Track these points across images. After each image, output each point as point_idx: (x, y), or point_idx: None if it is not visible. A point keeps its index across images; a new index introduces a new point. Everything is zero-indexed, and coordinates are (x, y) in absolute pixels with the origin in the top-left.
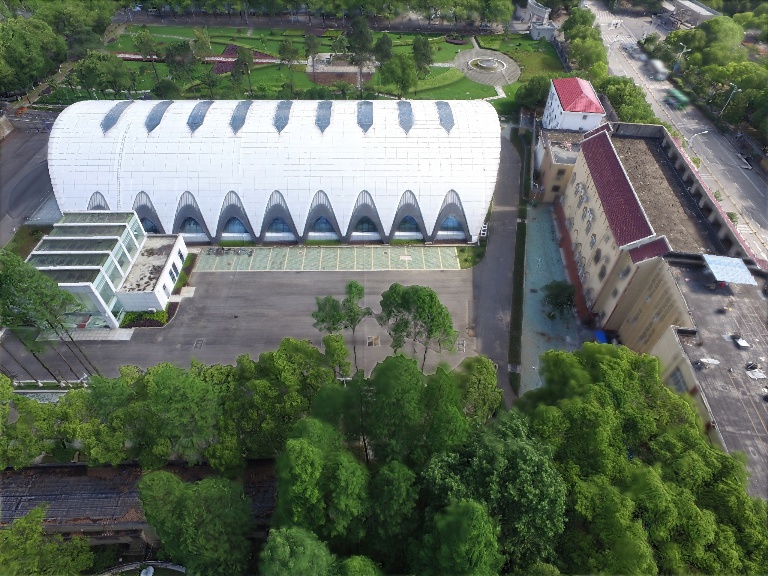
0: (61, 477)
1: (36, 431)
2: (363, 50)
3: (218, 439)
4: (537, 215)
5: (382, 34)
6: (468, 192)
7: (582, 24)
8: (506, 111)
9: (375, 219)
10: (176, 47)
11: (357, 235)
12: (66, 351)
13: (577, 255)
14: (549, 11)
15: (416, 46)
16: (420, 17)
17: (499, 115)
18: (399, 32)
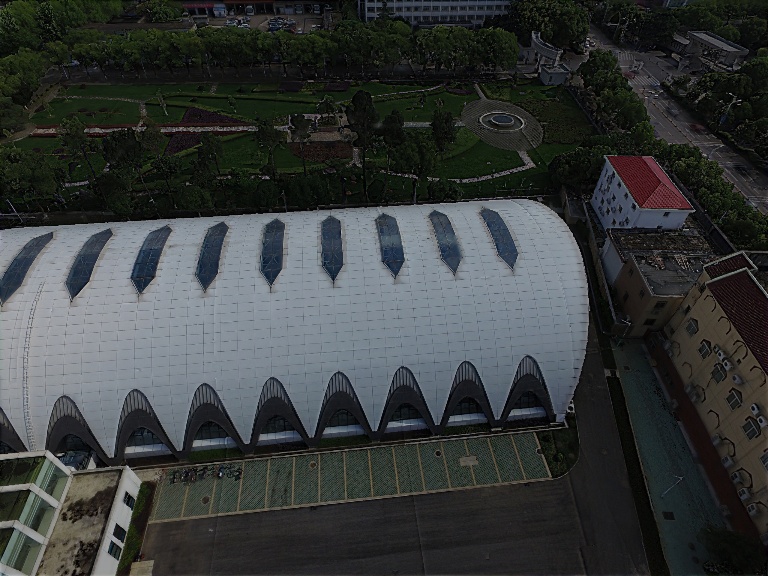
0: None
1: None
2: (368, 131)
3: None
4: (629, 360)
5: (371, 84)
6: (550, 357)
7: (604, 69)
8: (541, 188)
9: (420, 405)
10: (117, 137)
11: (393, 427)
12: None
13: (730, 461)
14: (561, 52)
15: (436, 124)
16: None
17: (535, 195)
18: (390, 81)
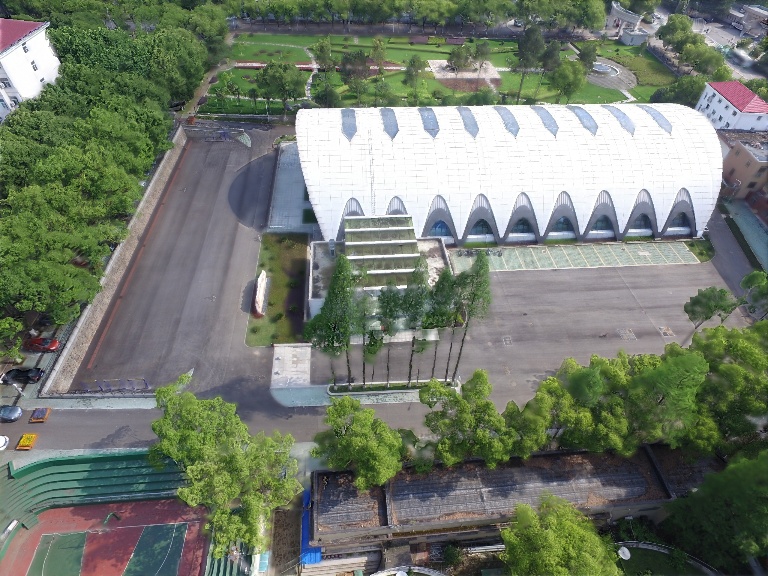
0: (502, 469)
1: (544, 421)
2: (535, 57)
3: (699, 421)
4: (737, 210)
5: (482, 41)
6: (698, 190)
7: (682, 30)
8: None
9: (612, 217)
10: (354, 55)
11: (592, 233)
12: (387, 353)
13: None
14: (641, 18)
15: (585, 52)
16: (508, 24)
17: None
18: (498, 39)
